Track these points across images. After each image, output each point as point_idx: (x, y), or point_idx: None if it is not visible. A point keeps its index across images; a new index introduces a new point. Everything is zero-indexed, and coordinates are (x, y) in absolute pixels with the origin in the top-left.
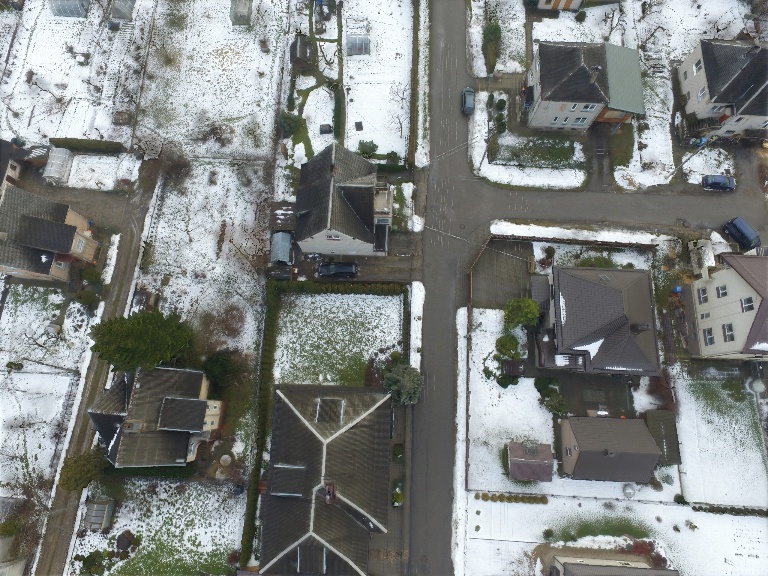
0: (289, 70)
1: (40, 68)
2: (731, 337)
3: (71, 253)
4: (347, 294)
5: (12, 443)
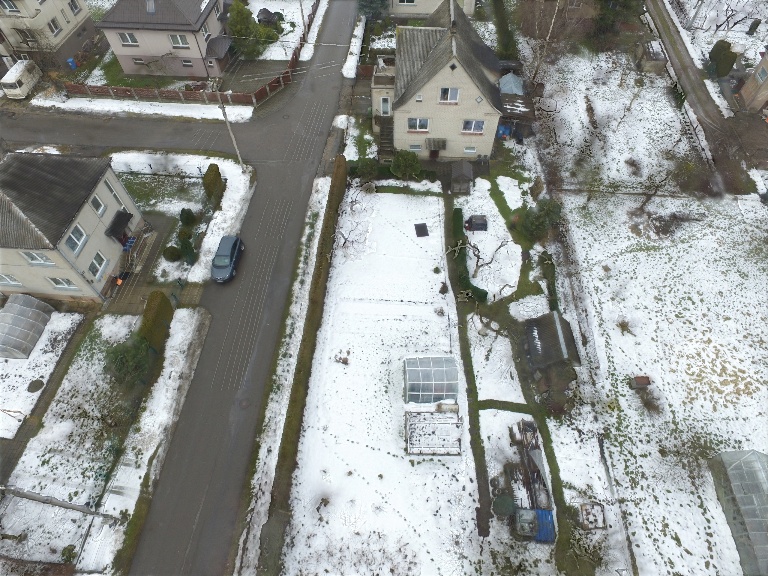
0: None
1: None
2: None
3: None
4: None
5: (714, 1)
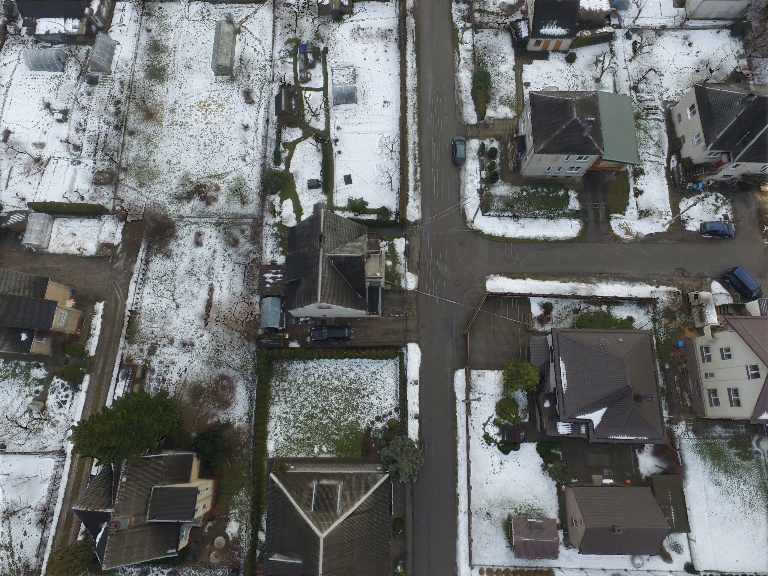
0: (274, 122)
1: (17, 126)
2: (737, 402)
3: (52, 329)
4: (341, 359)
5: None
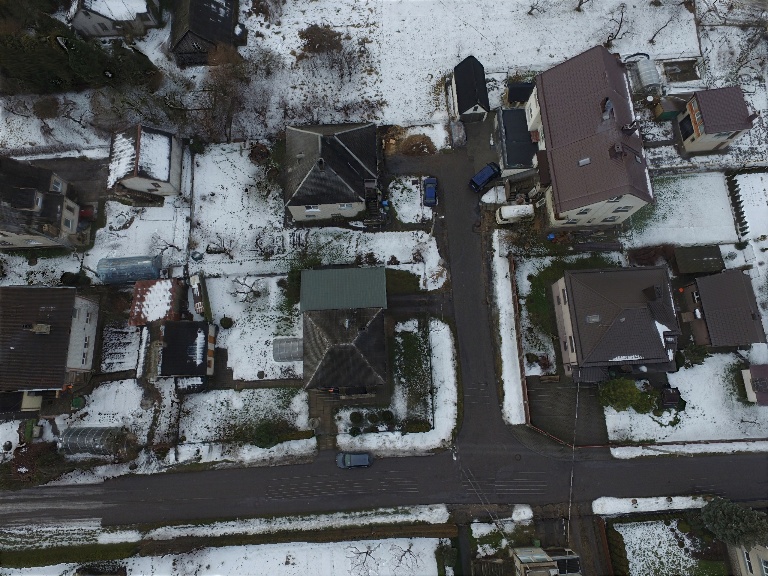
0: None
1: None
2: (625, 207)
3: None
4: None
5: None
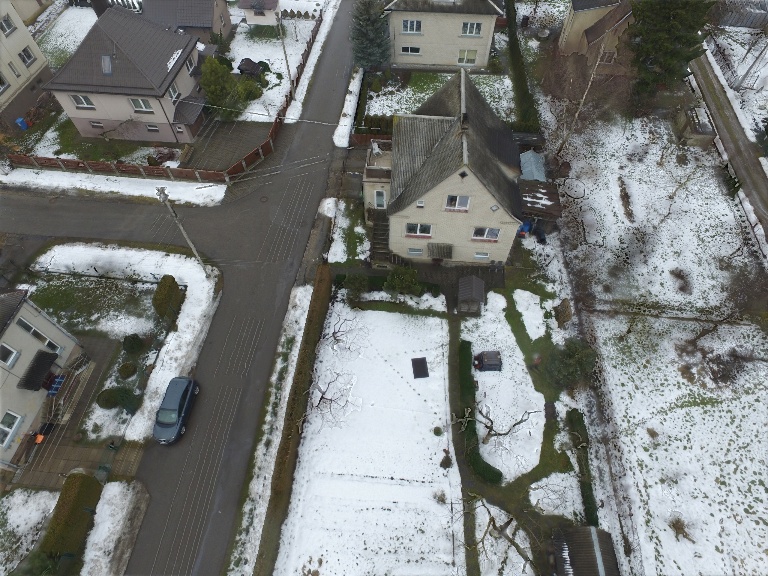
0: None
1: None
2: (7, 25)
3: None
4: None
5: None
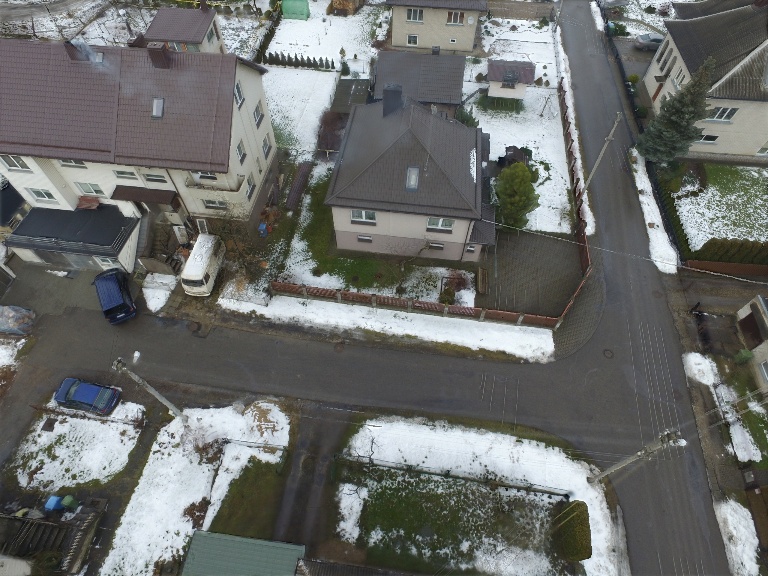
0: None
1: None
2: None
3: None
4: None
5: None
